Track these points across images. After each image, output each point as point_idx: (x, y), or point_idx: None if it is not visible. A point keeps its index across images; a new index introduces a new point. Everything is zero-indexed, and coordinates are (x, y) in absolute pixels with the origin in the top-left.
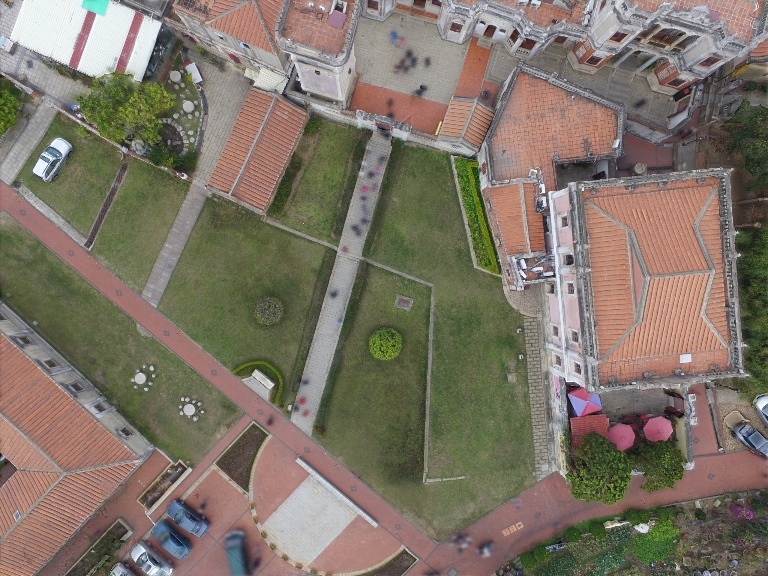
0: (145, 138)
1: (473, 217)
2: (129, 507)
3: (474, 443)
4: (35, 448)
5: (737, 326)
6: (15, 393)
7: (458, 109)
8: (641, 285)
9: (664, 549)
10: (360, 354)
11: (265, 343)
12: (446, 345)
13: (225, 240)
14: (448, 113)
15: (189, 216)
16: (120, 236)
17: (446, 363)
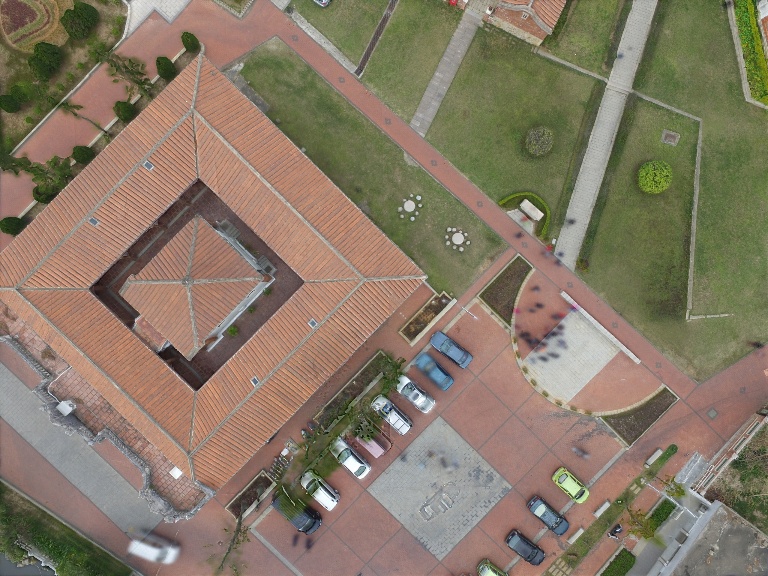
0: None
1: (749, 48)
2: (390, 339)
3: (739, 279)
4: (335, 254)
5: None
6: (312, 200)
7: None
8: None
9: None
10: (625, 189)
11: (531, 175)
12: (714, 180)
13: (494, 71)
14: None
15: (460, 45)
16: (390, 64)
17: (714, 198)
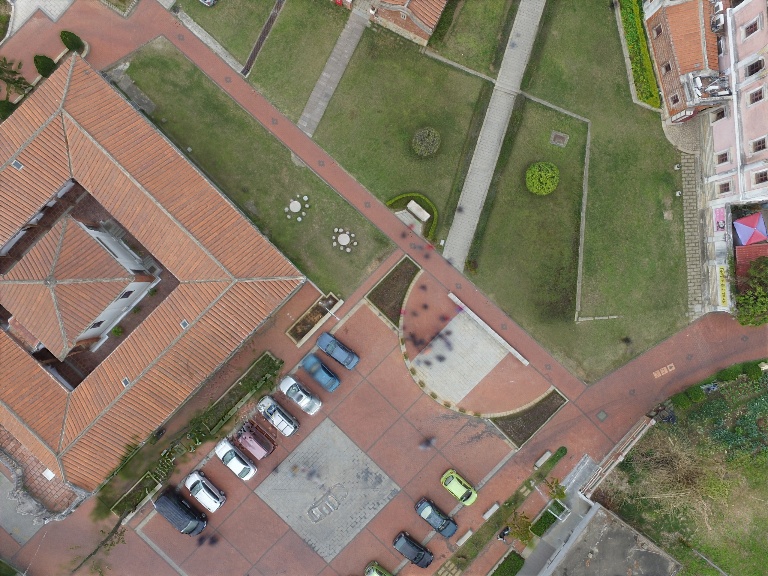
0: None
1: (635, 49)
2: (277, 340)
3: (628, 281)
4: (206, 254)
5: None
6: (185, 200)
7: None
8: None
9: None
10: (514, 190)
11: (419, 176)
12: (602, 181)
13: (382, 71)
14: None
15: (348, 45)
16: (277, 64)
17: (602, 199)
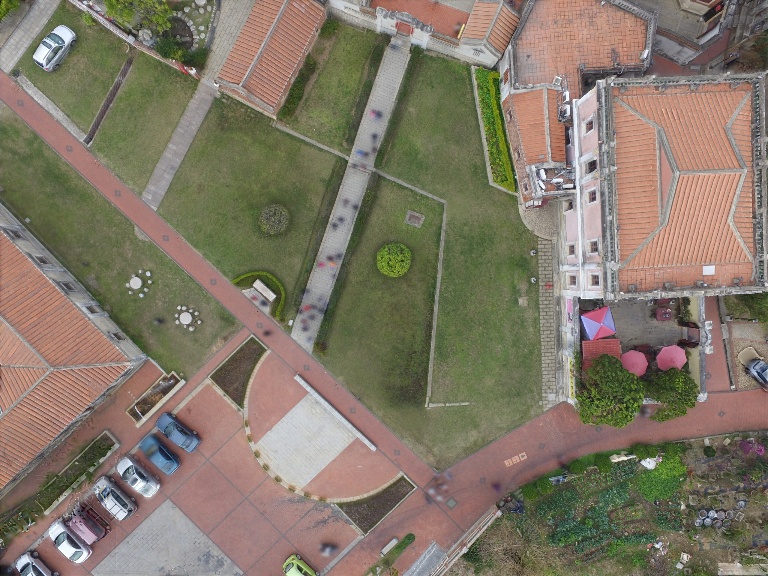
0: (153, 29)
1: (491, 131)
2: (117, 419)
3: (480, 368)
4: (21, 341)
5: (764, 237)
6: (3, 283)
7: (483, 11)
8: (669, 182)
9: (670, 487)
10: (367, 270)
11: (268, 254)
12: (456, 264)
13: (232, 144)
14: (472, 15)
15: (195, 116)
16: (122, 133)
17: (455, 283)
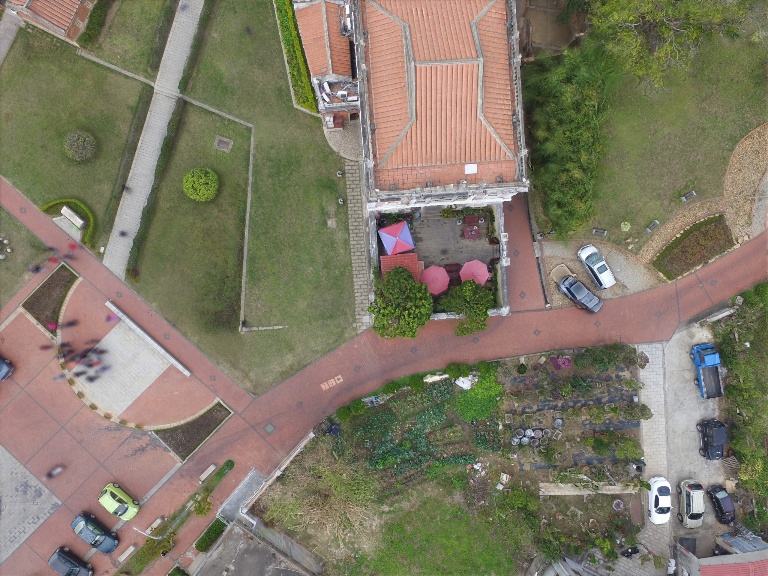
0: None
1: (291, 53)
2: None
3: (292, 291)
4: None
5: (521, 133)
6: None
7: None
8: None
9: (487, 407)
10: (177, 196)
11: (78, 181)
12: (265, 188)
13: (39, 73)
14: None
15: (1, 46)
16: None
17: (264, 206)
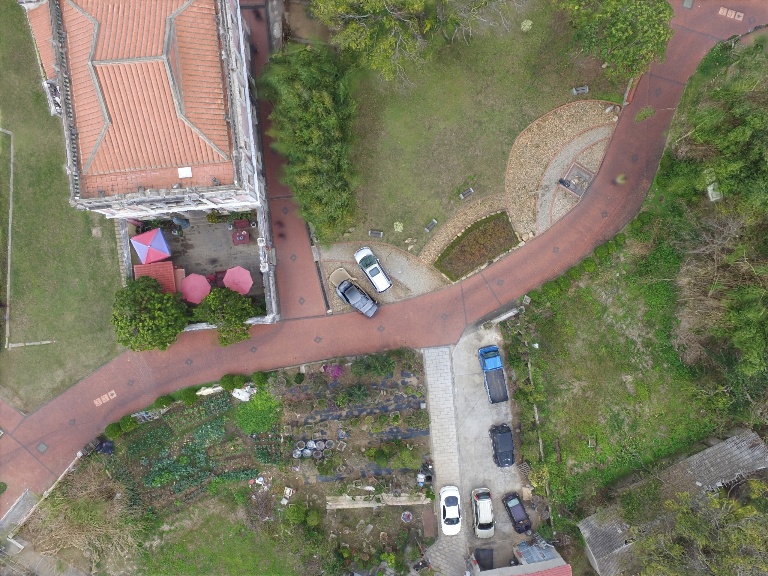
0: None
1: None
2: None
3: (59, 304)
4: None
5: None
6: None
7: None
8: None
9: (267, 418)
10: None
11: None
12: (26, 197)
13: None
14: None
15: None
16: None
17: (26, 217)
